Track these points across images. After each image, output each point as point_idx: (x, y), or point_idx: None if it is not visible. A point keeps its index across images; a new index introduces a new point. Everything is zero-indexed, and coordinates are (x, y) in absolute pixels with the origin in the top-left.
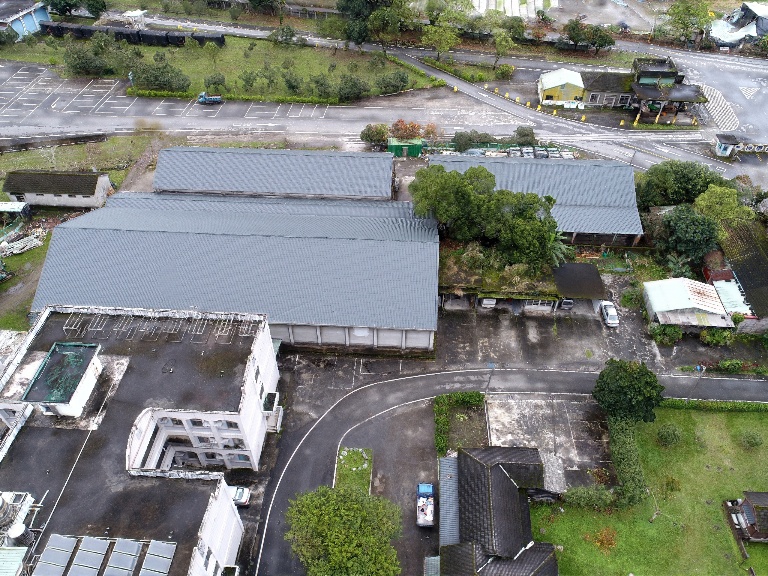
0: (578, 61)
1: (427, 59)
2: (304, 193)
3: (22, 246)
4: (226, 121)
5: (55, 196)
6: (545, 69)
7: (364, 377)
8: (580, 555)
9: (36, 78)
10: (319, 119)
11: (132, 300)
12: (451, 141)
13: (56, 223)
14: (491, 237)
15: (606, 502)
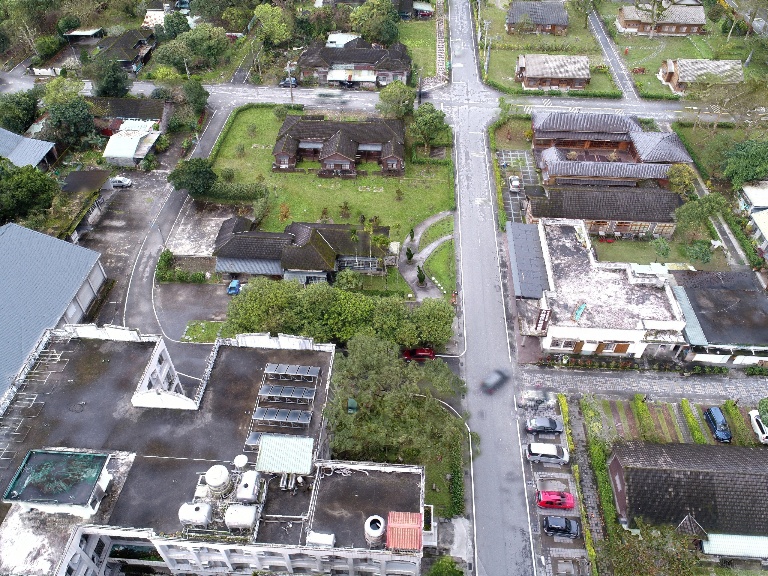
0: None
1: None
2: None
3: None
4: None
5: None
6: None
7: None
8: None
9: None
10: None
11: None
12: None
13: None
14: (14, 206)
15: None
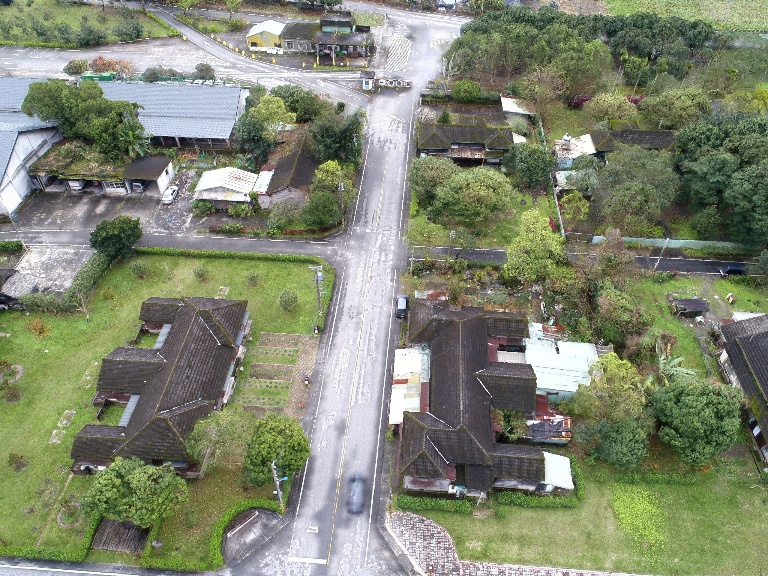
0: (310, 18)
1: (178, 15)
2: None
3: None
4: None
5: None
6: None
7: None
8: (19, 339)
9: None
10: (50, 59)
11: None
12: (141, 75)
13: None
14: (81, 134)
15: (46, 303)
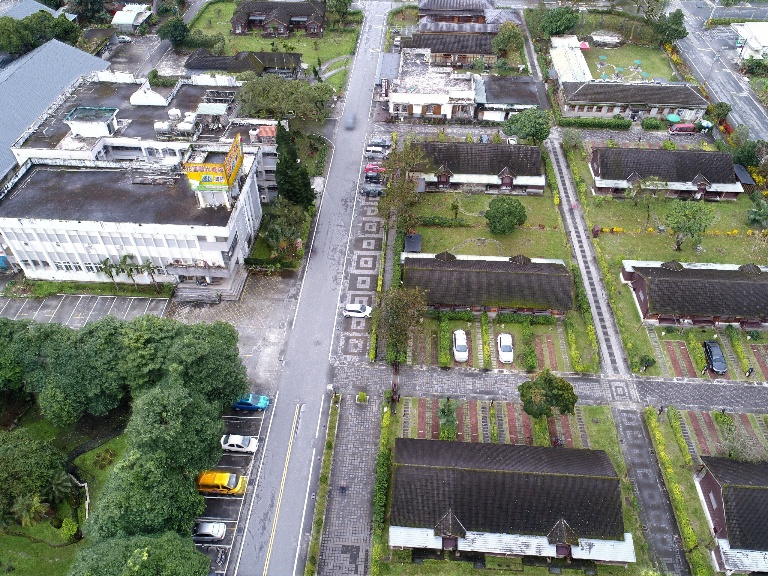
0: None
1: None
2: None
3: None
4: None
5: None
6: None
7: None
8: None
9: None
10: None
11: (8, 153)
12: None
13: None
14: None
15: None
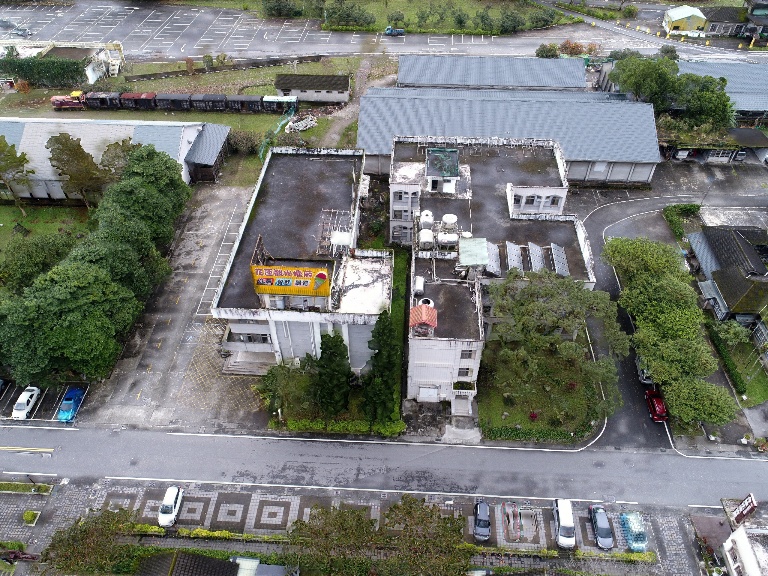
0: (687, 4)
1: (561, 3)
2: (518, 85)
3: (305, 125)
4: (415, 47)
5: (315, 92)
6: (662, 10)
7: (603, 200)
8: None
9: (238, 19)
10: (490, 45)
11: None
12: (609, 57)
13: (319, 112)
14: (682, 106)
15: None
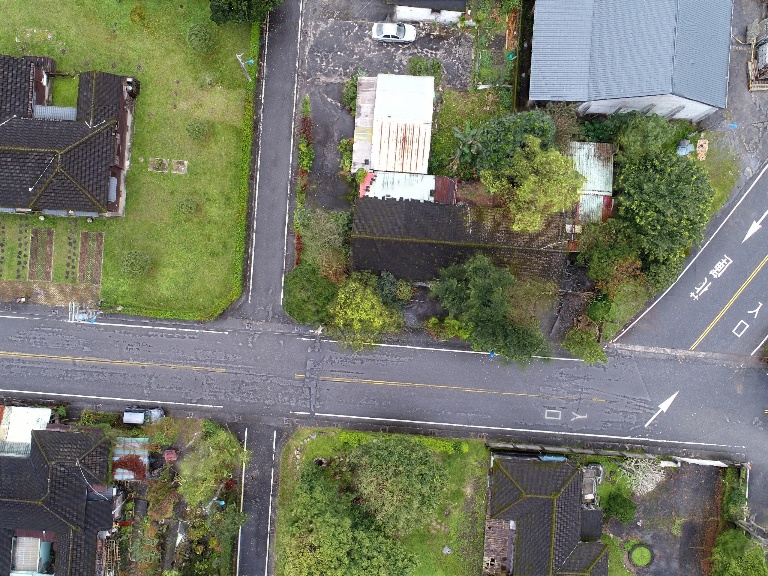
0: None
1: None
2: None
3: None
4: None
5: None
6: None
7: None
8: None
9: None
10: None
11: None
12: None
13: None
14: None
15: None
